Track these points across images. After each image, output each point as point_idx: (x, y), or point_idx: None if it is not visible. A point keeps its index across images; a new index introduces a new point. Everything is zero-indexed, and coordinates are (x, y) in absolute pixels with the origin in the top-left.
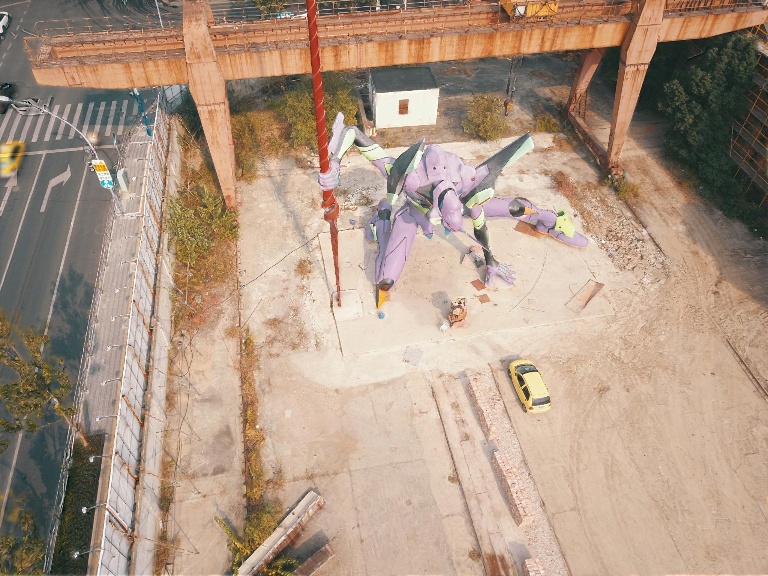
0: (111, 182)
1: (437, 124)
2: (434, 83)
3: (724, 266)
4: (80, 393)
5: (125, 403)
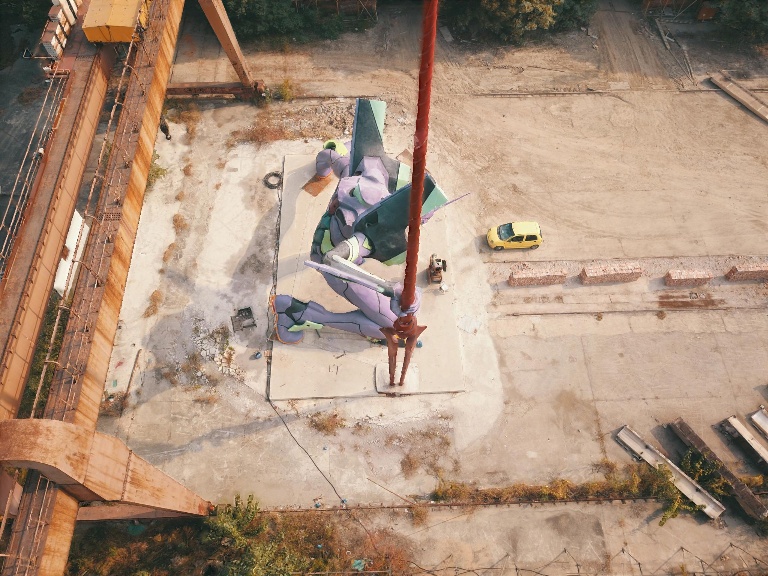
0: None
1: None
2: None
3: (393, 65)
4: None
5: None
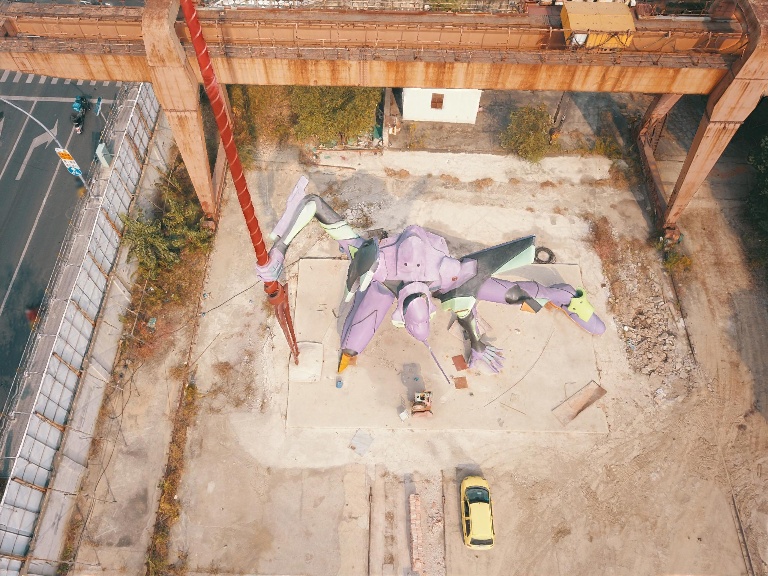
0: (79, 170)
1: (476, 124)
2: None
3: (765, 390)
4: (5, 424)
5: (16, 484)
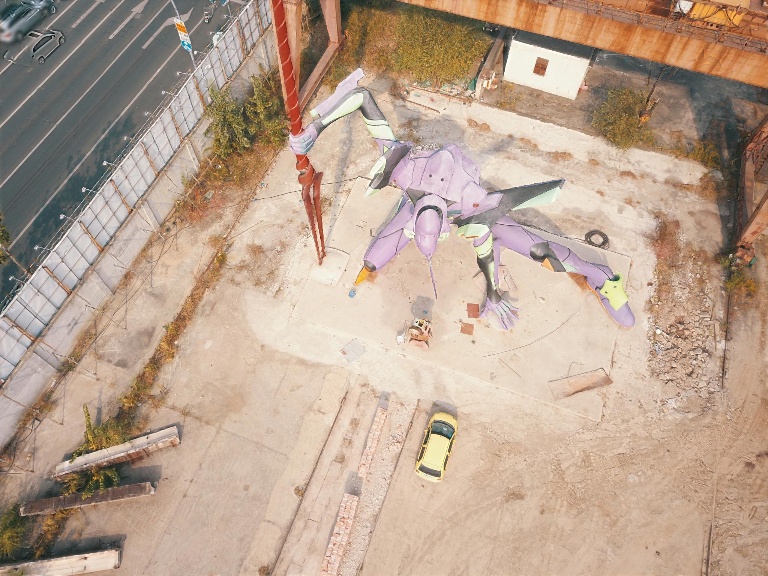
0: (190, 45)
1: (576, 100)
2: (590, 51)
3: None
4: None
5: (45, 273)
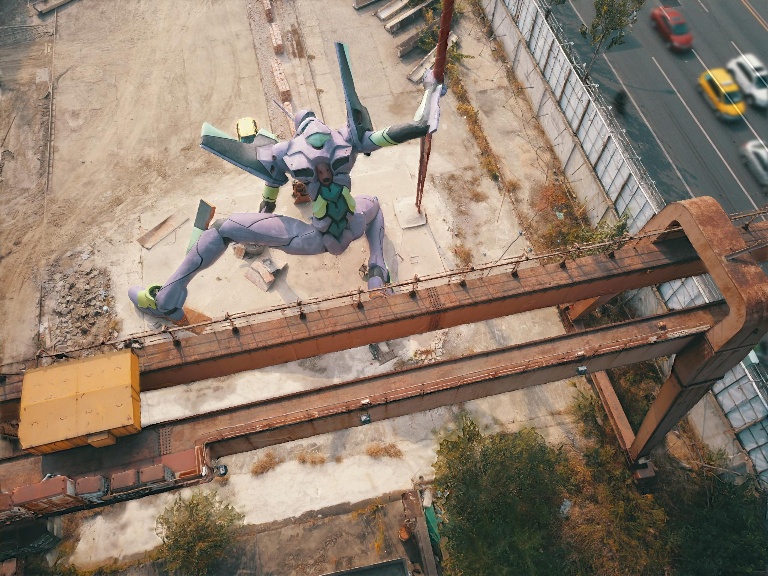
0: None
1: None
2: None
3: None
4: None
5: None
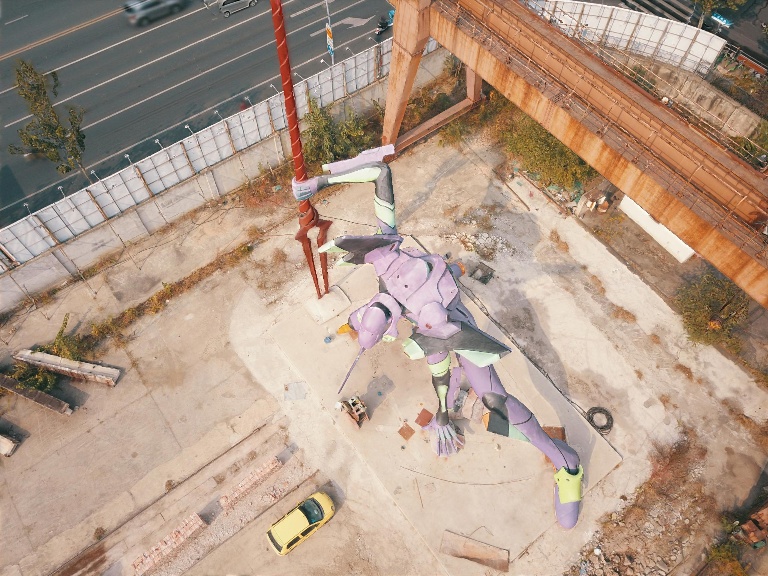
0: (333, 51)
1: (683, 264)
2: None
3: None
4: None
5: (87, 196)
